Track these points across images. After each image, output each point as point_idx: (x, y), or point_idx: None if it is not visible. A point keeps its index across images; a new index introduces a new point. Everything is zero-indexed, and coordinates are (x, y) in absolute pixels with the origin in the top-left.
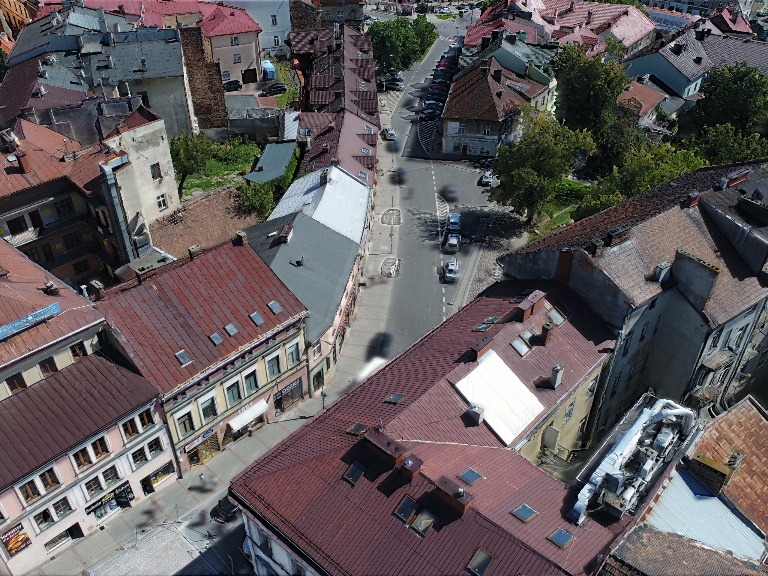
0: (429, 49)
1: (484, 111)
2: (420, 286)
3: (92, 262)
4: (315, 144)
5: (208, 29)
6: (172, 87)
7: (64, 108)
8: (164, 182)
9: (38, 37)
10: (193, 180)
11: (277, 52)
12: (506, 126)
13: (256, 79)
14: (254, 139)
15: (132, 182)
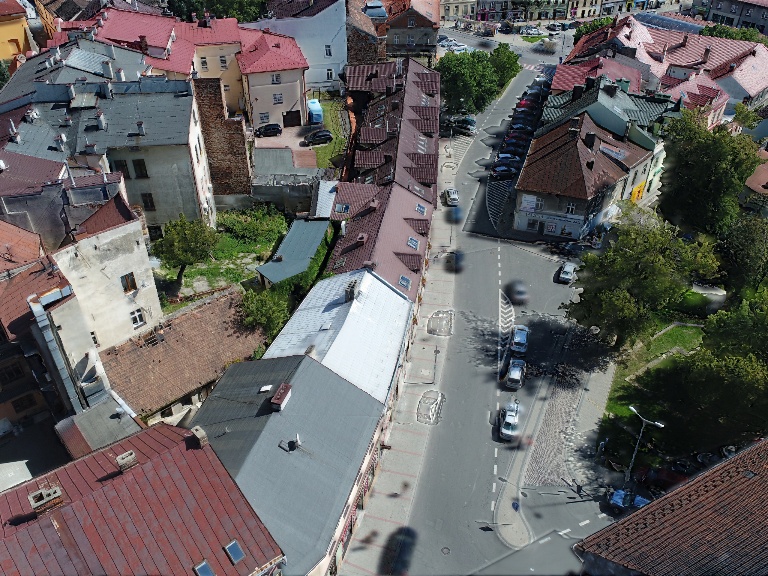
0: (510, 81)
1: (569, 185)
2: (465, 443)
3: (39, 396)
4: (351, 227)
5: (246, 64)
6: (175, 155)
7: (19, 195)
8: (140, 294)
9: (29, 80)
10: (199, 264)
11: (330, 87)
12: (595, 203)
13: (299, 122)
14: (282, 209)
15: (77, 318)
